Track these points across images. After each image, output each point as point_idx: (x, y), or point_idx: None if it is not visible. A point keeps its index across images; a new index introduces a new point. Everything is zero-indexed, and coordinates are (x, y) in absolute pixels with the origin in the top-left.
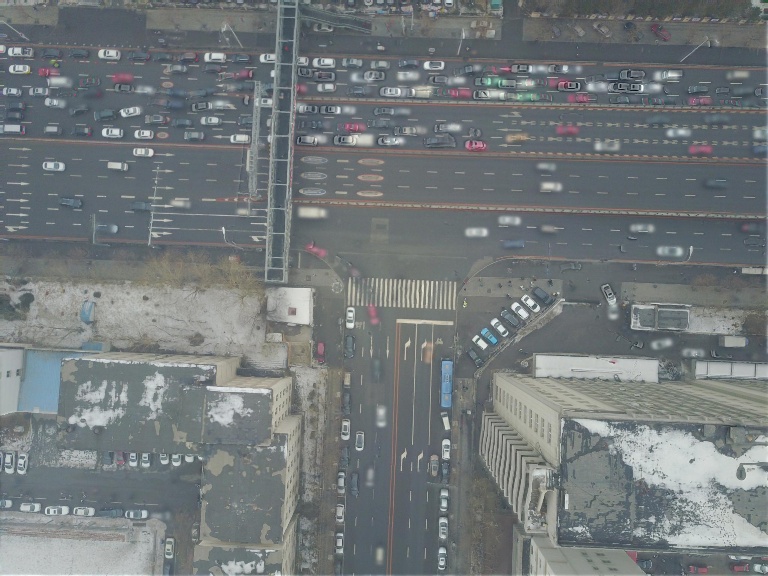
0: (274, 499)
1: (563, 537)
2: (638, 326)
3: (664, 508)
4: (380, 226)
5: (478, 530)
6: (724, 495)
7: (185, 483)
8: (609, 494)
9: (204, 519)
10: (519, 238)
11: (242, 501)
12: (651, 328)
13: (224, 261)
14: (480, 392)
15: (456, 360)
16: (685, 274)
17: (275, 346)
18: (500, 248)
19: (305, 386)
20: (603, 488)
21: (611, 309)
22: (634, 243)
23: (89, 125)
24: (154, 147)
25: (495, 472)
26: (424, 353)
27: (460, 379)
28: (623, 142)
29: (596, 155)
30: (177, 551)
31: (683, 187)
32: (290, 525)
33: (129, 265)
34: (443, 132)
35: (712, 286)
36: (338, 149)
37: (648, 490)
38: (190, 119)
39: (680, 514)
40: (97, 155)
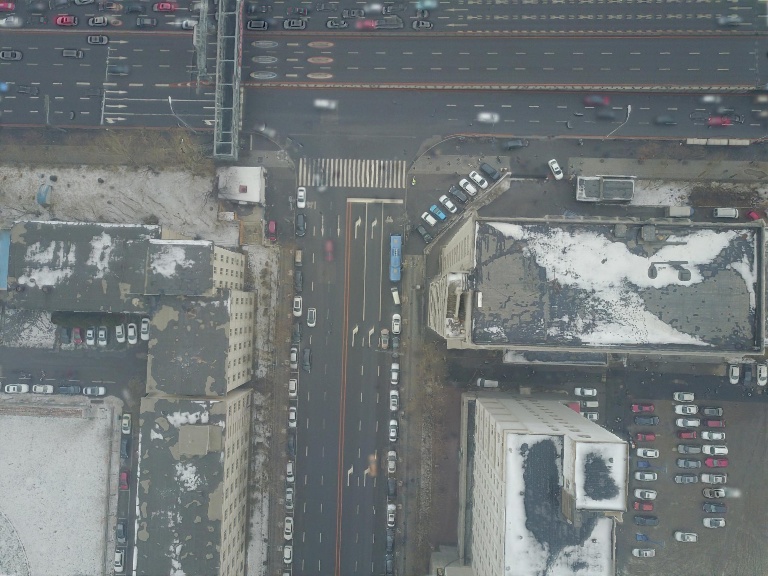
0: (218, 352)
1: (479, 338)
2: (583, 197)
3: (577, 307)
4: (330, 107)
5: (429, 403)
6: (636, 293)
7: (141, 361)
8: (523, 295)
9: (150, 373)
10: (467, 117)
11: (187, 354)
12: (596, 199)
13: (172, 133)
14: (429, 268)
15: (406, 237)
16: (631, 148)
17: (228, 226)
18: (448, 127)
19: (258, 265)
20: (517, 289)
21: (558, 184)
22: (581, 119)
23: (44, 14)
24: (108, 34)
25: (434, 323)
26: (375, 231)
27: (410, 256)
28: (568, 18)
29: (541, 32)
30: (134, 427)
31: (628, 61)
32: (240, 390)
33: (85, 149)
34: (391, 14)
35: (658, 159)
36: (288, 33)
37: (561, 290)
38: (143, 6)
39: (593, 313)
40: (53, 43)
